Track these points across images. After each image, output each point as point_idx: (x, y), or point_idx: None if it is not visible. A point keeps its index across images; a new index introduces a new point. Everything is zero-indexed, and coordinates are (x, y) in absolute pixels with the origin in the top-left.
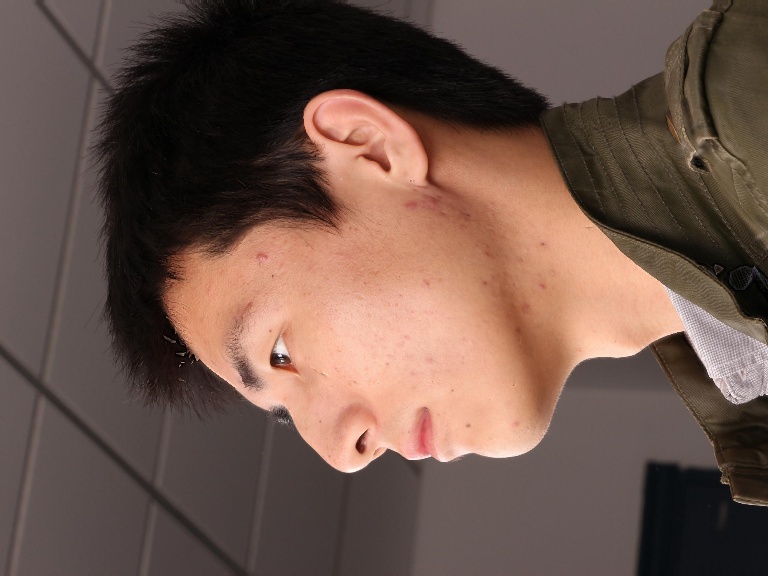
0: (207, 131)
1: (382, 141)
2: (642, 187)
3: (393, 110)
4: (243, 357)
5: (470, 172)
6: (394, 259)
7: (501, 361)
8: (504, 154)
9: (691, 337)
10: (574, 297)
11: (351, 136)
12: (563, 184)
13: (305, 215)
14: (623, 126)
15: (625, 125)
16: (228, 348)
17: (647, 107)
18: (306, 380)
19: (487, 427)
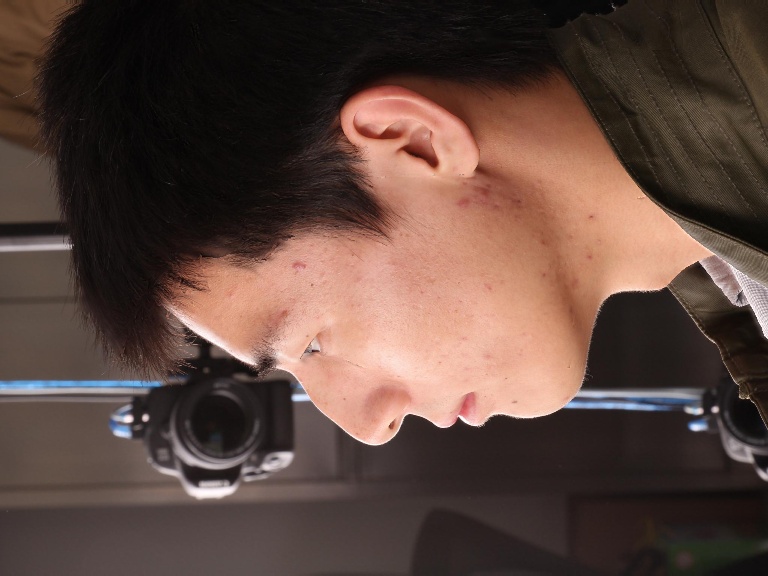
0: (230, 138)
1: (421, 128)
2: (705, 162)
3: (428, 90)
4: (273, 360)
5: (513, 149)
6: (452, 265)
7: (559, 348)
8: (542, 120)
9: (752, 306)
10: (615, 258)
11: (388, 127)
12: (611, 153)
13: (348, 222)
14: (675, 90)
15: (678, 89)
16: (255, 350)
17: (695, 62)
18: (326, 358)
19: (536, 403)
